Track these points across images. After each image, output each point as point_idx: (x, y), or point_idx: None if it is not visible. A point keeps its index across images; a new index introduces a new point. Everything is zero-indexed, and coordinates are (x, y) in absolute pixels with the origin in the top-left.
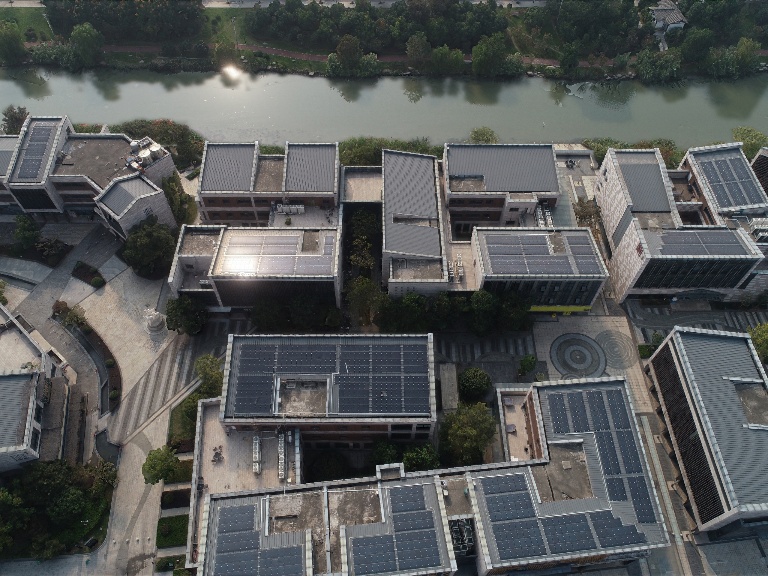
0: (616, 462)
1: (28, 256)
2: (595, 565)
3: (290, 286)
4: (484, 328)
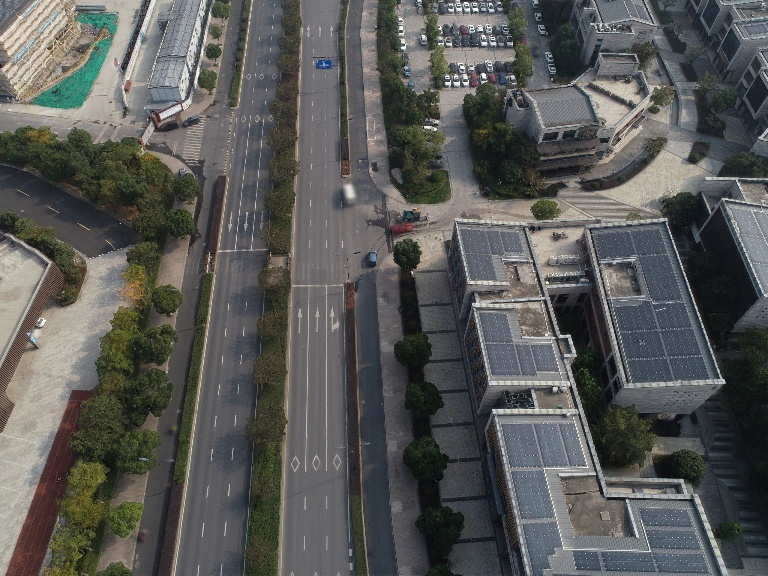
0: (619, 568)
1: (702, 114)
2: (507, 574)
3: (739, 268)
4: (761, 470)
